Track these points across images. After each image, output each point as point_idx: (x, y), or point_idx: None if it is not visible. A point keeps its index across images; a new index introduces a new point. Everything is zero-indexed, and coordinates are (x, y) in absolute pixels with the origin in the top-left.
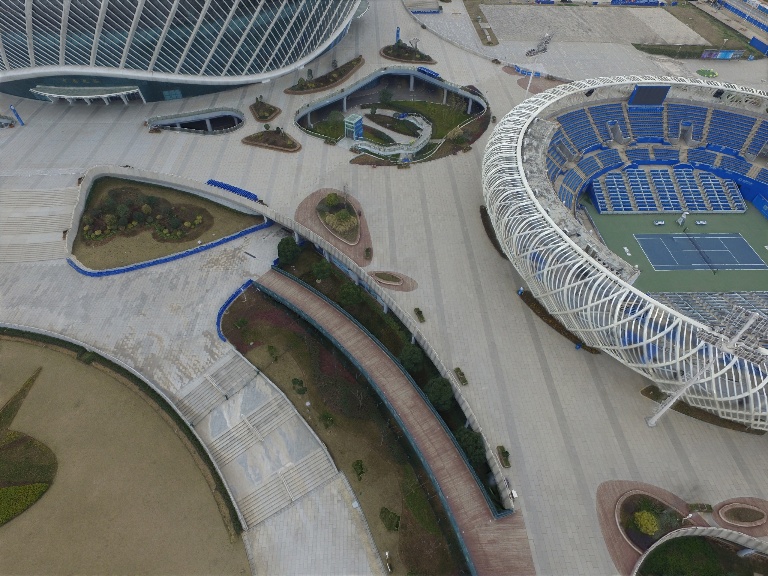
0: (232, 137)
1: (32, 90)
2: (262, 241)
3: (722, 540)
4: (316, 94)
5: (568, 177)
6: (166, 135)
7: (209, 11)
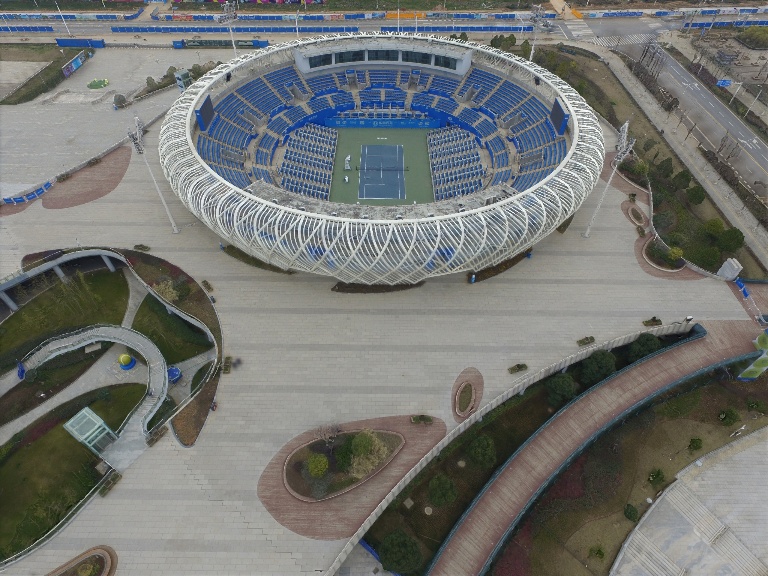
0: None
1: None
2: None
3: None
4: None
5: None
6: None
7: None
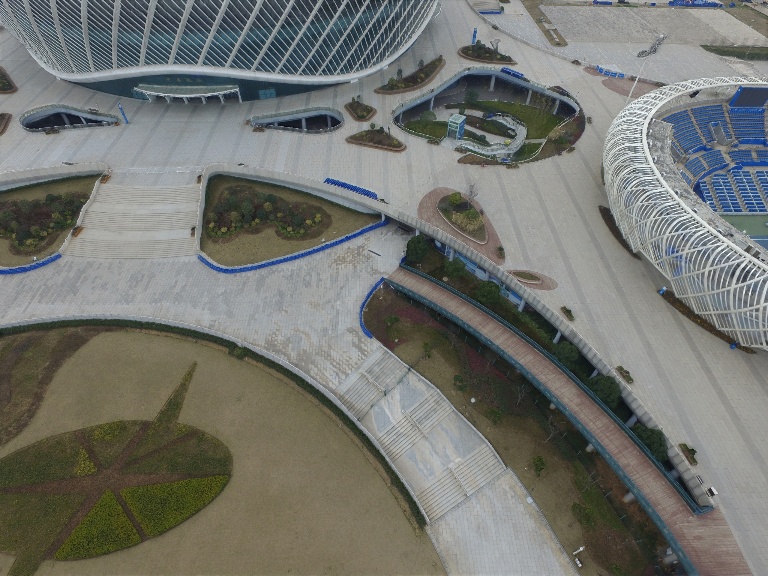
0: (335, 136)
1: (136, 89)
2: (382, 239)
3: None
4: (406, 94)
5: None
6: (270, 134)
7: (319, 11)
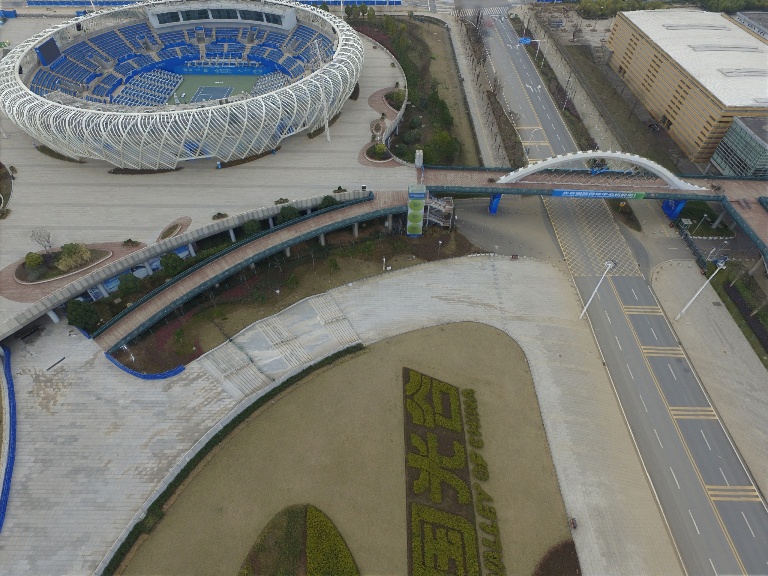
0: None
1: None
2: (36, 356)
3: None
4: None
5: None
6: None
7: None
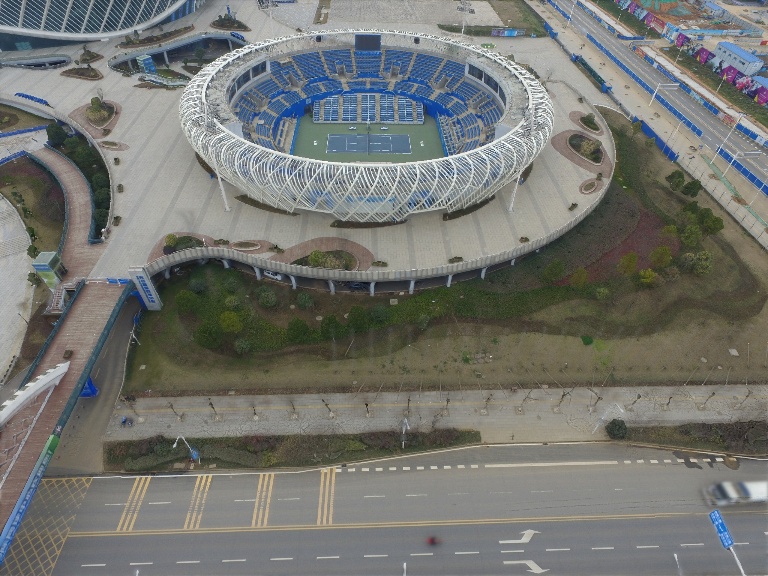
0: (55, 72)
1: None
2: None
3: (253, 274)
4: None
5: (289, 96)
6: (5, 70)
7: None
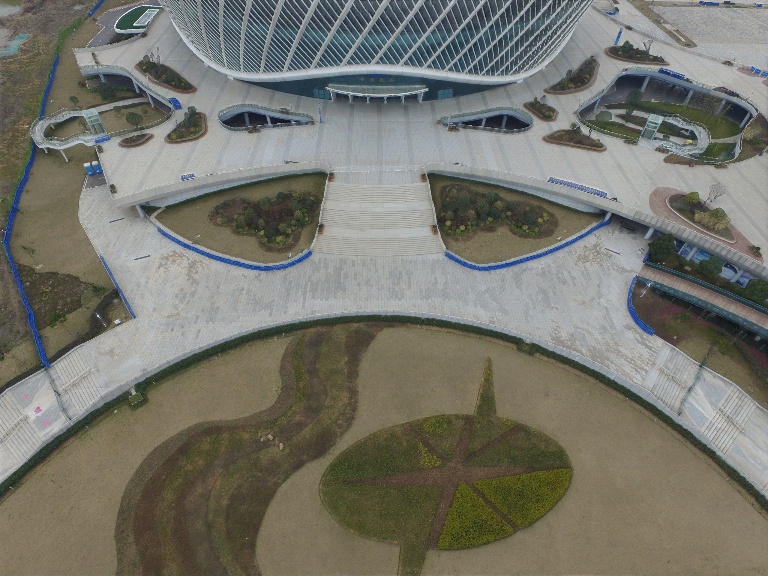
0: (531, 136)
1: (328, 88)
2: (613, 238)
3: None
4: (577, 94)
5: None
6: (466, 133)
7: (526, 12)
